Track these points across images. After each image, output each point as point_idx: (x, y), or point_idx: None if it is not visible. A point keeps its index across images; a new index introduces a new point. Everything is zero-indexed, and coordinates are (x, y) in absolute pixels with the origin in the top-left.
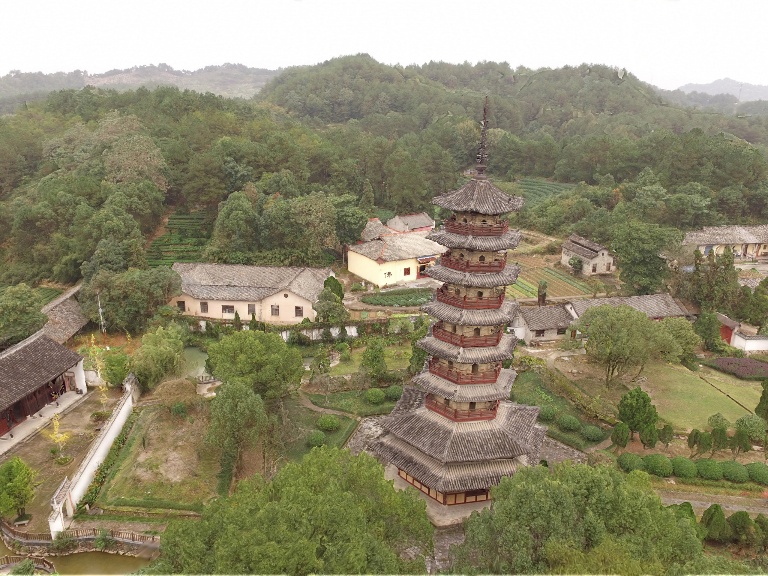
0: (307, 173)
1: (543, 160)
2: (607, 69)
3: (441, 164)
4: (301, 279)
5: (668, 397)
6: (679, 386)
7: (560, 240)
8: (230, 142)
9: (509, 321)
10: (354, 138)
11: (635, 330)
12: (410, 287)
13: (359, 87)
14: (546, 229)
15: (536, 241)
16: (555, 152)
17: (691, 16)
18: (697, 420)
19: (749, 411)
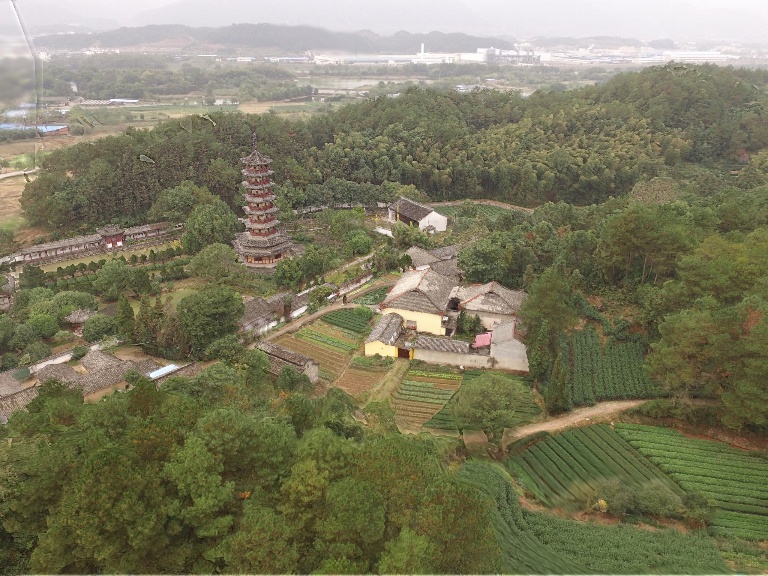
0: (604, 252)
1: None
2: None
3: None
4: (427, 255)
5: None
6: None
7: None
8: (667, 205)
9: None
10: None
11: None
12: None
13: None
14: None
15: None
16: None
17: (191, 103)
18: (179, 294)
19: None
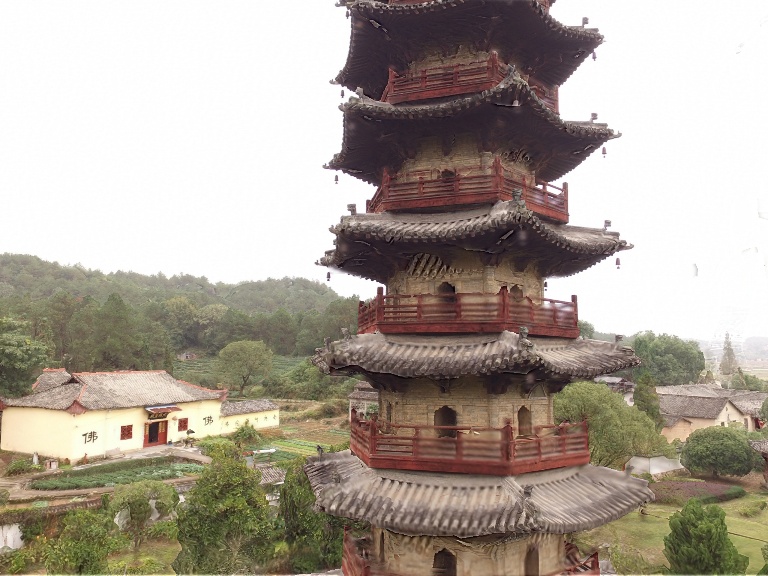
0: None
1: (279, 334)
2: (309, 281)
3: (150, 337)
4: None
5: (649, 543)
6: (639, 527)
7: (336, 399)
8: None
9: (617, 242)
10: (18, 301)
11: (621, 405)
12: (133, 458)
13: (24, 283)
14: (310, 394)
15: (301, 407)
16: (292, 325)
17: None
18: None
19: (759, 540)
